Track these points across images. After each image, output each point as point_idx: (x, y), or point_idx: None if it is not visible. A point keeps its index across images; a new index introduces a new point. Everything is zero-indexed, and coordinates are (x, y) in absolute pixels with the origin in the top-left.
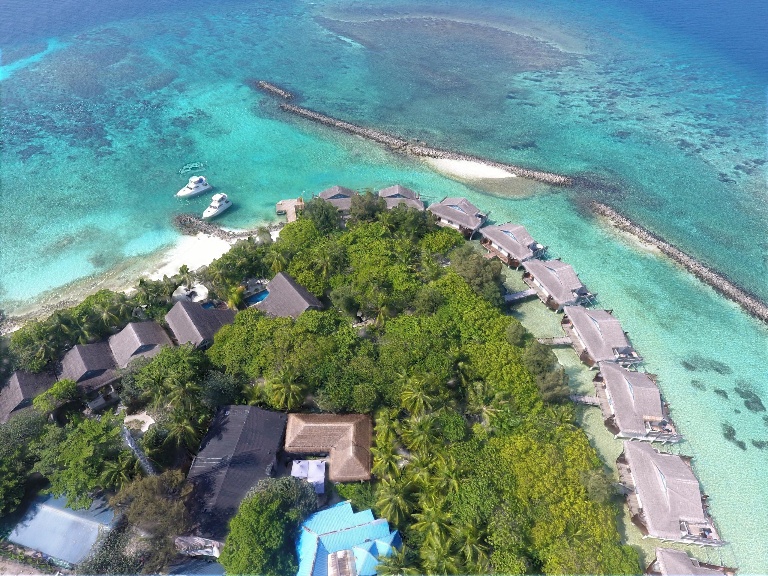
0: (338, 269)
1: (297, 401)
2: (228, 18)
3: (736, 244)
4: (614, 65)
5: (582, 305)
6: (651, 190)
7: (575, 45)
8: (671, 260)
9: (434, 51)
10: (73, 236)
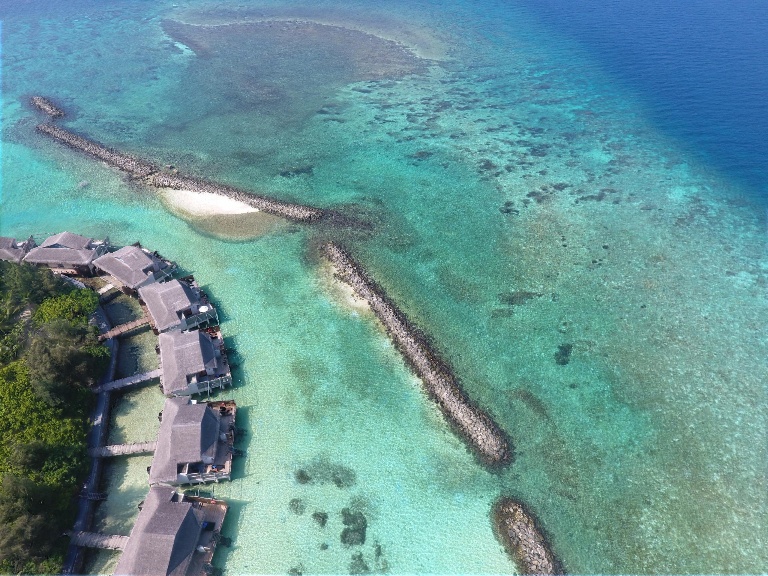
0: None
1: None
2: (64, 23)
3: (470, 295)
4: (466, 72)
5: (216, 389)
6: (412, 225)
7: (437, 50)
8: (375, 320)
9: (272, 58)
10: None
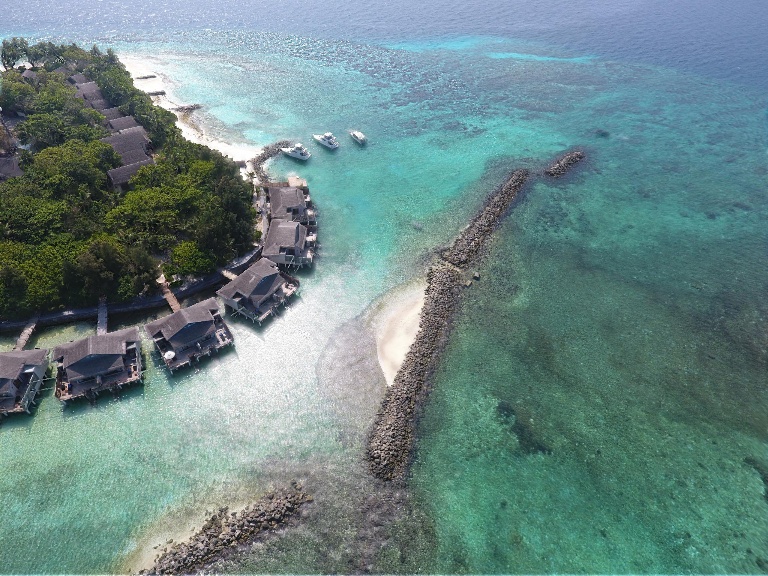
0: (147, 184)
1: (20, 167)
2: None
3: None
4: None
5: None
6: None
7: None
8: None
9: None
10: (270, 113)
